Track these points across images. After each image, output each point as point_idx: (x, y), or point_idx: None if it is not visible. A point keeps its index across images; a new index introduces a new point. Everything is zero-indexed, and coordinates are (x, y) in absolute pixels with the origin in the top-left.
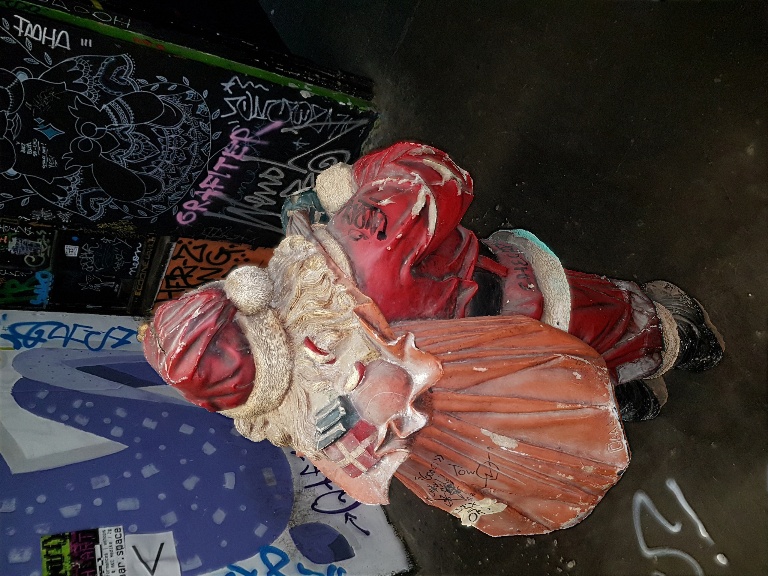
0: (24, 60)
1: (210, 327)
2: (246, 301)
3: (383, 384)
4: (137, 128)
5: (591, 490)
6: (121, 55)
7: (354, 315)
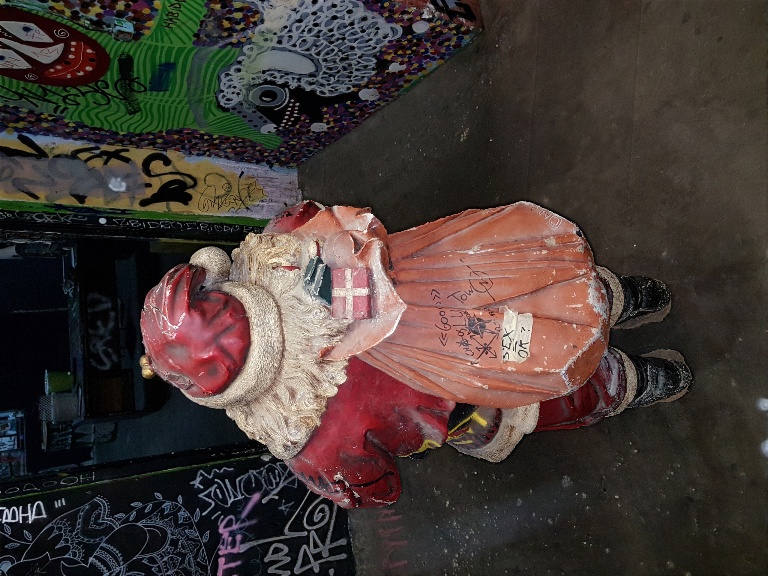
0: (5, 548)
1: (186, 272)
2: (207, 257)
3: (334, 234)
4: (128, 568)
5: (575, 259)
6: (94, 500)
7: (293, 235)
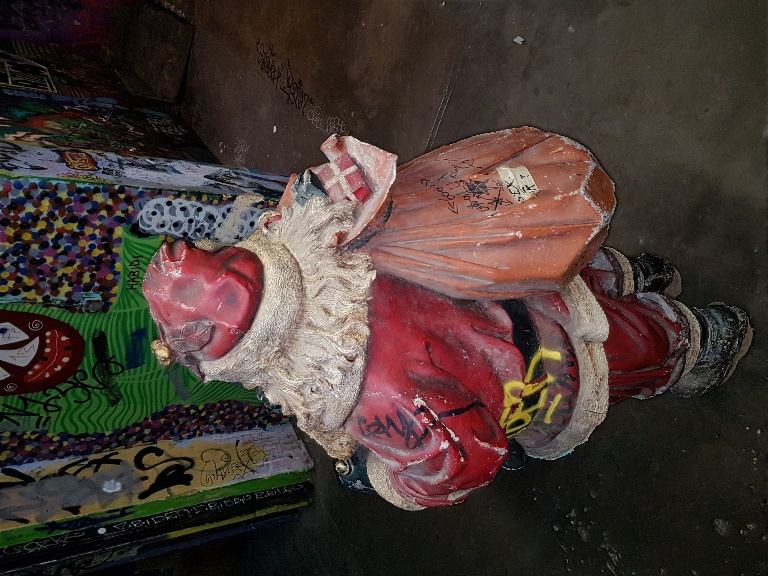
0: None
1: None
2: None
3: None
4: None
5: None
6: None
7: None
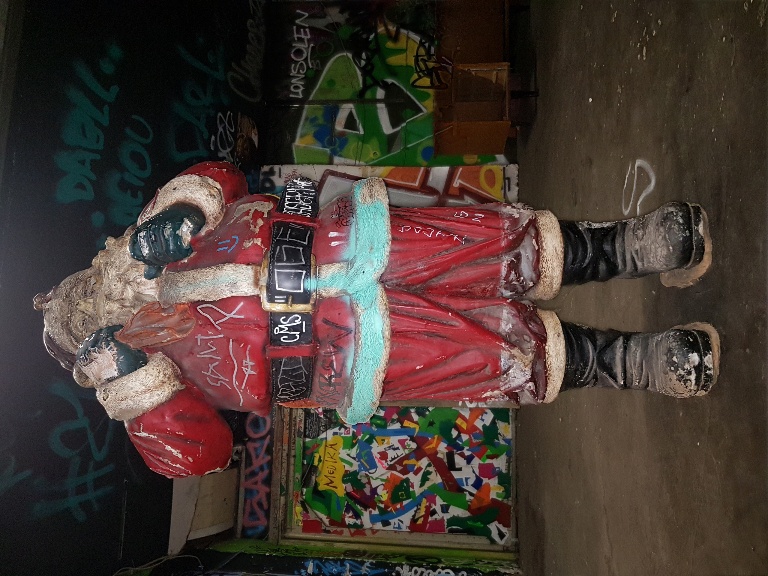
0: None
1: None
2: None
3: None
4: None
5: None
6: None
7: None
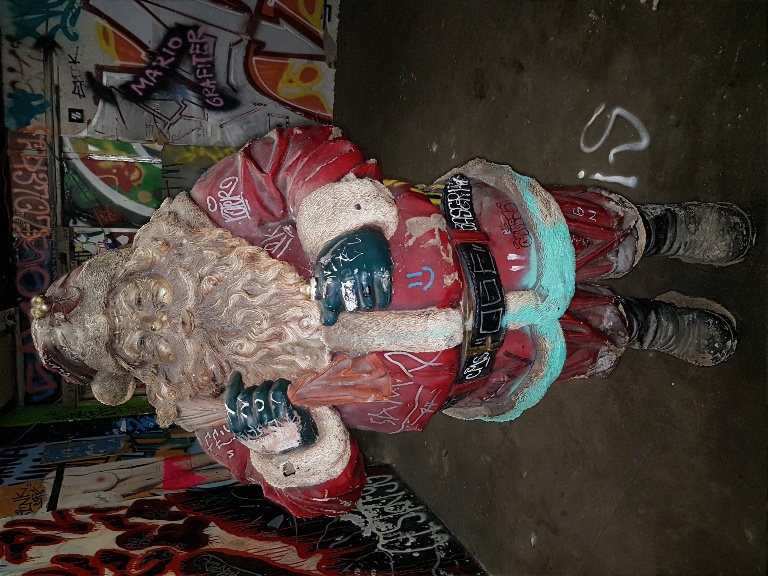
0: None
1: None
2: None
3: None
4: None
5: None
6: None
7: None
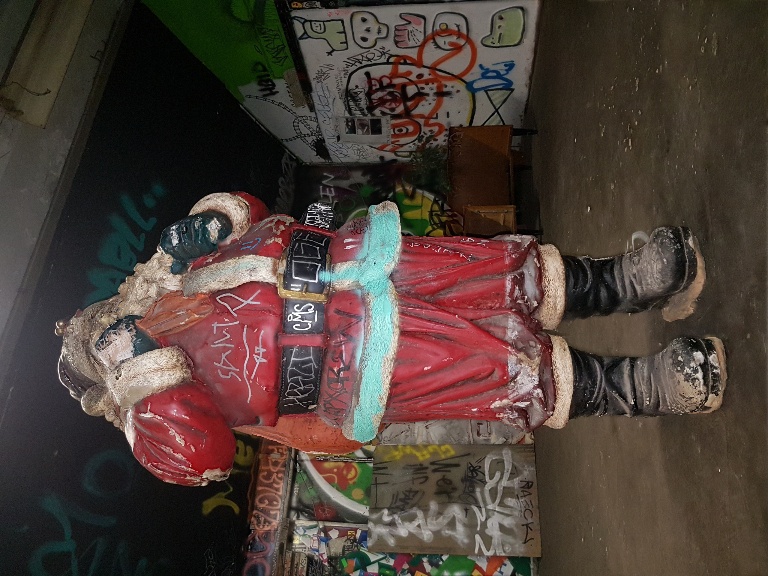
0: None
1: None
2: None
3: None
4: None
5: None
6: None
7: None
